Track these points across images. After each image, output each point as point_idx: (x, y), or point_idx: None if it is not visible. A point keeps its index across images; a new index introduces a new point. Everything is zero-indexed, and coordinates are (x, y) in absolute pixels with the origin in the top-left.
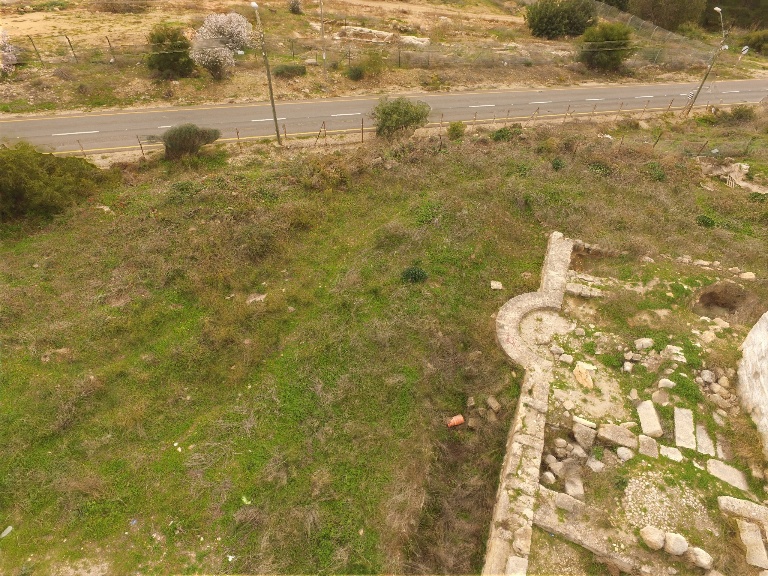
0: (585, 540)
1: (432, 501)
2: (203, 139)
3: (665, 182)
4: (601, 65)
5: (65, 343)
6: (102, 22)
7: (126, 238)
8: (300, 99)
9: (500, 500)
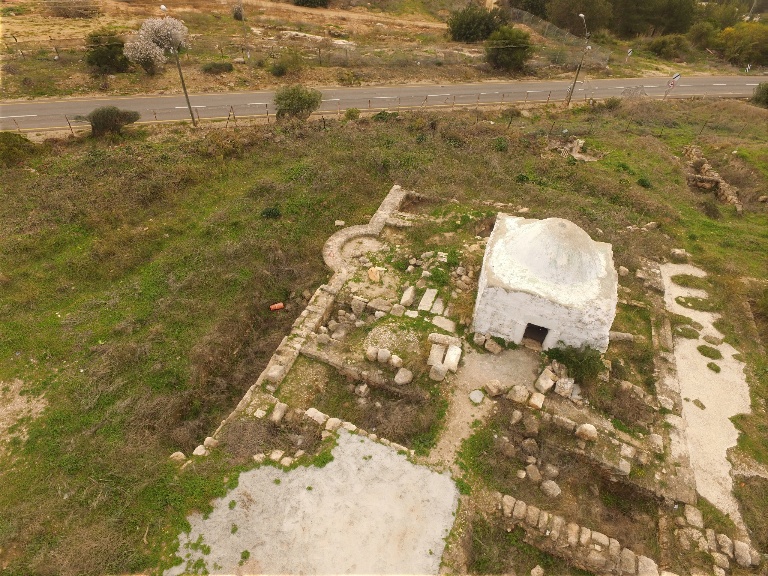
0: (330, 359)
1: (243, 350)
2: (124, 119)
3: (506, 152)
4: (505, 65)
5: None
6: (53, 26)
7: (45, 190)
8: (225, 91)
9: None
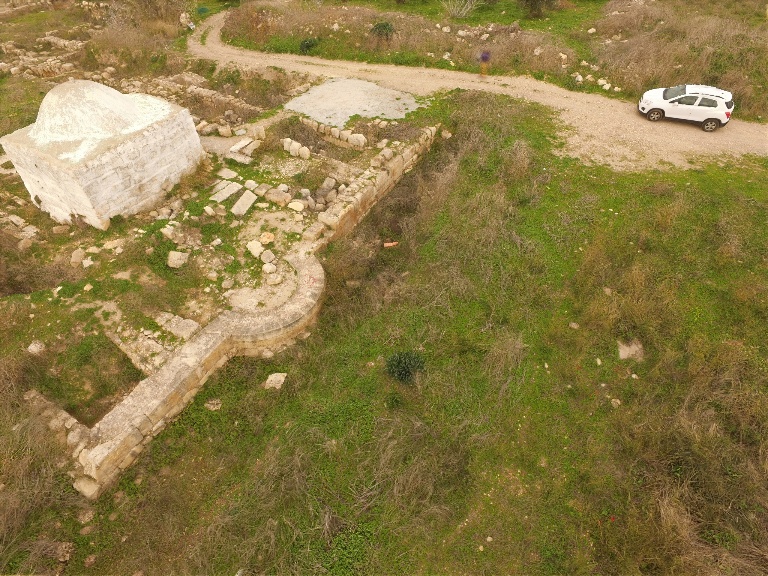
0: None
1: None
2: None
3: None
4: None
5: None
6: None
7: None
8: None
9: None
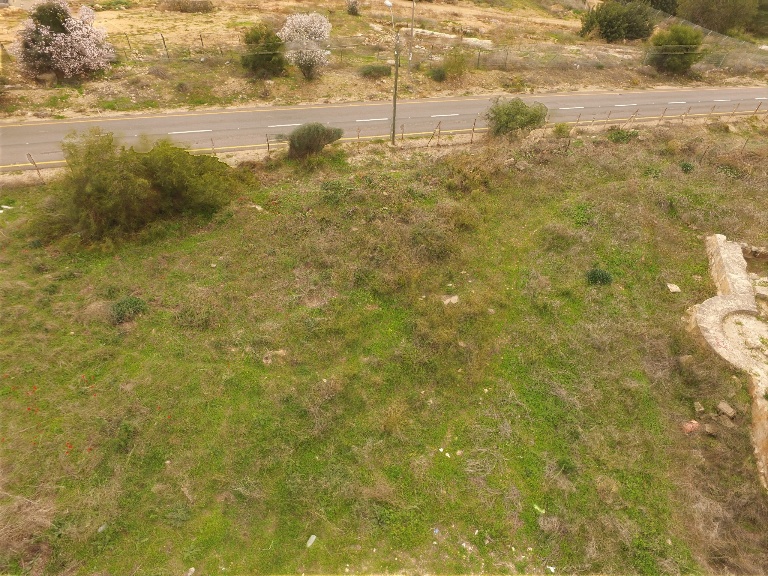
0: None
1: None
2: (327, 138)
3: None
4: (671, 69)
5: (280, 345)
6: (175, 21)
7: (293, 238)
8: (391, 100)
9: None
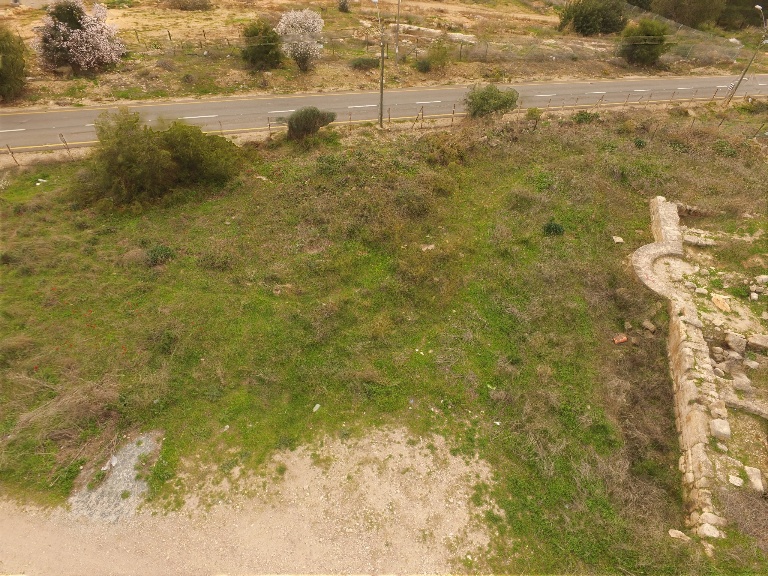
0: (764, 411)
1: None
2: (322, 121)
3: (736, 158)
4: (640, 60)
5: (287, 280)
6: (177, 18)
7: (294, 201)
8: None
9: (686, 387)
